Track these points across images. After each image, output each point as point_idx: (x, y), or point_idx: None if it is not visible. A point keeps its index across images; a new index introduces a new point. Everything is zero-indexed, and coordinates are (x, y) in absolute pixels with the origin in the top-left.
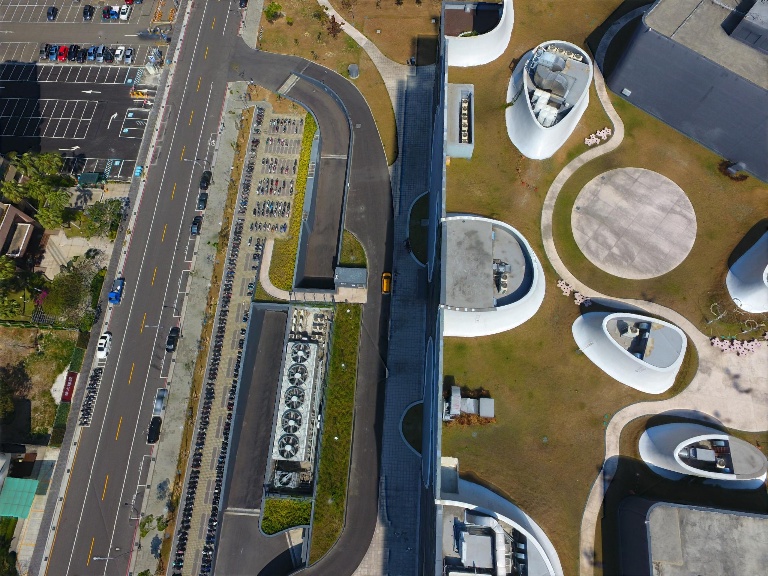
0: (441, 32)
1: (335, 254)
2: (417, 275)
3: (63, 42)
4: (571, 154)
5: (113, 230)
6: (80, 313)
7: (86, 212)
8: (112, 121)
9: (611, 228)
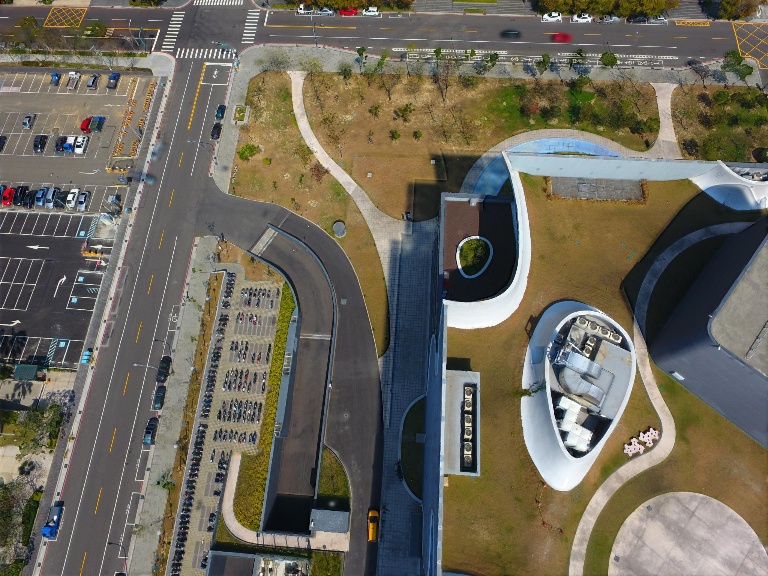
0: (440, 239)
1: (314, 465)
2: (410, 521)
3: (10, 180)
4: (606, 469)
5: (52, 437)
6: (8, 551)
7: (20, 420)
8: (59, 287)
9: None
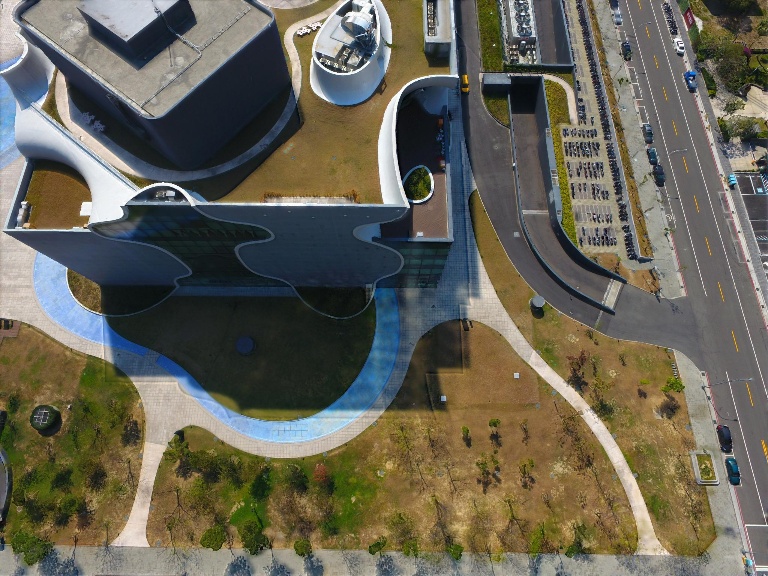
0: None
1: None
2: None
3: None
4: None
5: None
6: (712, 65)
7: (757, 126)
8: None
9: None
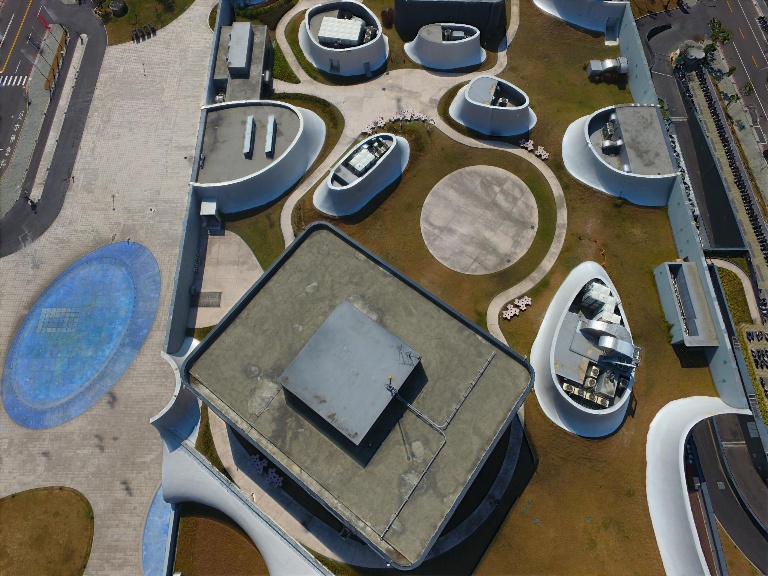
0: None
1: None
2: None
3: None
4: (545, 285)
5: None
6: None
7: None
8: None
9: (501, 209)
